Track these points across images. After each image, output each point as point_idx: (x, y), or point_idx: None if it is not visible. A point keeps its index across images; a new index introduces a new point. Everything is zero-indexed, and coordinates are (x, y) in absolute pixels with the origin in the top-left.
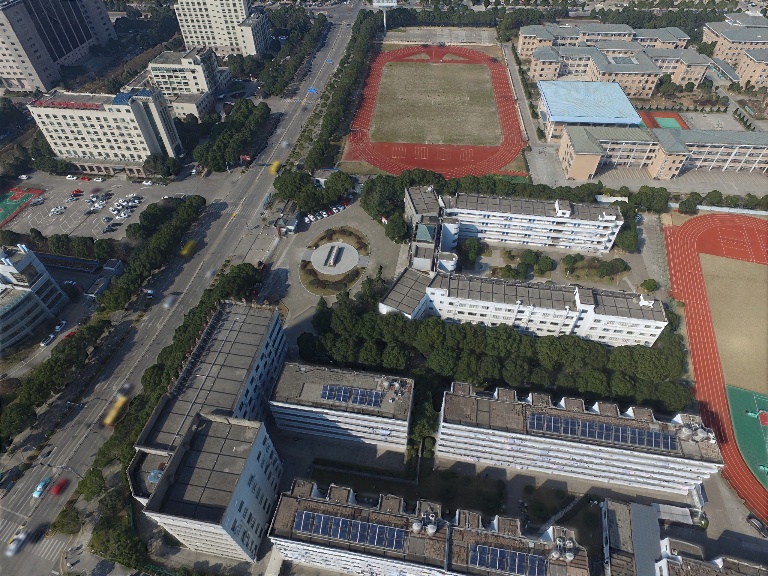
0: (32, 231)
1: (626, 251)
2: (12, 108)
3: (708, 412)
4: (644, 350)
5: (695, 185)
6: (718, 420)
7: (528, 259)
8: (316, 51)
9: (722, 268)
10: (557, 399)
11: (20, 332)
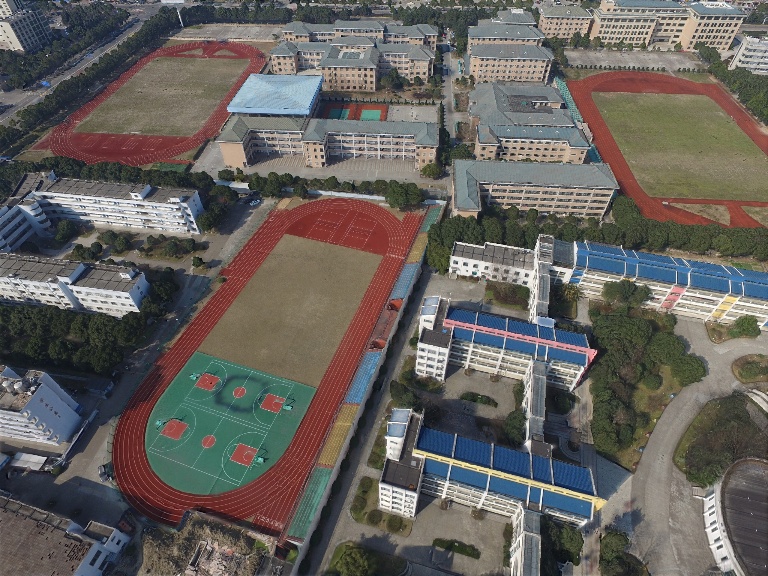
0: None
1: (218, 232)
2: None
3: (156, 375)
4: (97, 318)
5: (340, 172)
6: (159, 382)
7: (105, 239)
8: (99, 47)
9: (292, 248)
10: (17, 363)
11: None
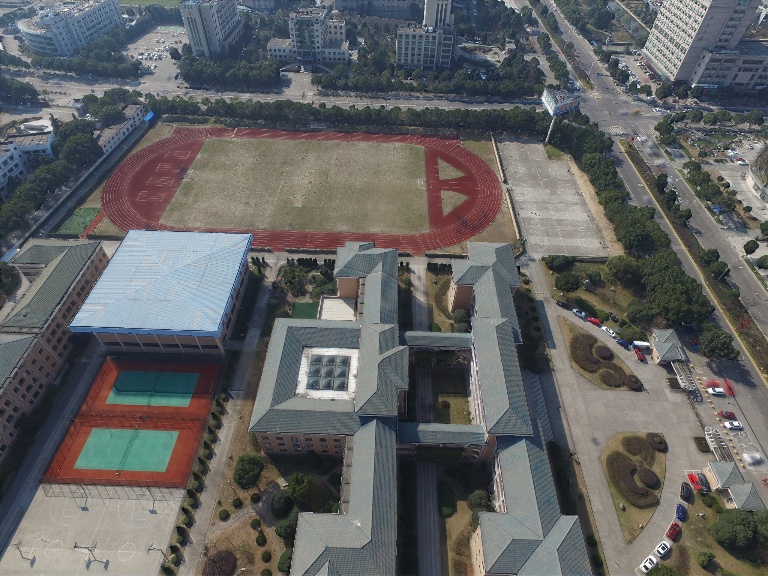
0: (111, 29)
1: None
2: (285, 1)
3: None
4: None
5: None
6: None
7: None
8: (450, 99)
9: None
10: None
11: (37, 48)
